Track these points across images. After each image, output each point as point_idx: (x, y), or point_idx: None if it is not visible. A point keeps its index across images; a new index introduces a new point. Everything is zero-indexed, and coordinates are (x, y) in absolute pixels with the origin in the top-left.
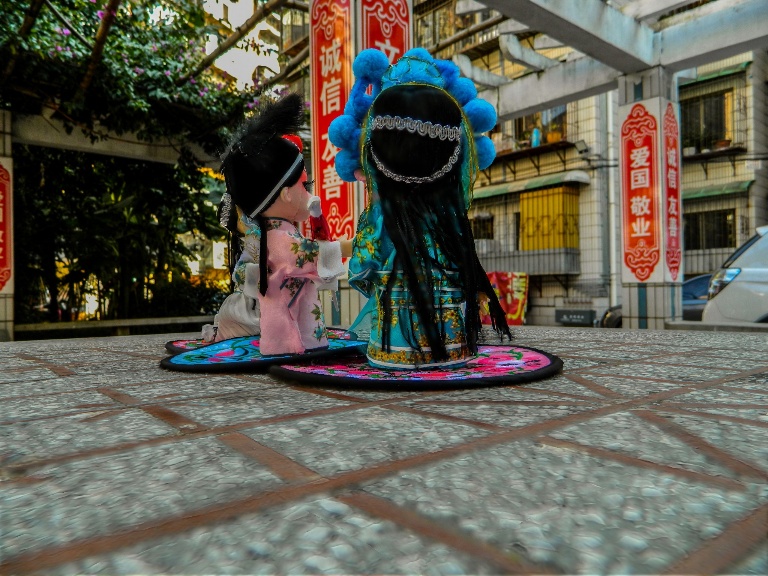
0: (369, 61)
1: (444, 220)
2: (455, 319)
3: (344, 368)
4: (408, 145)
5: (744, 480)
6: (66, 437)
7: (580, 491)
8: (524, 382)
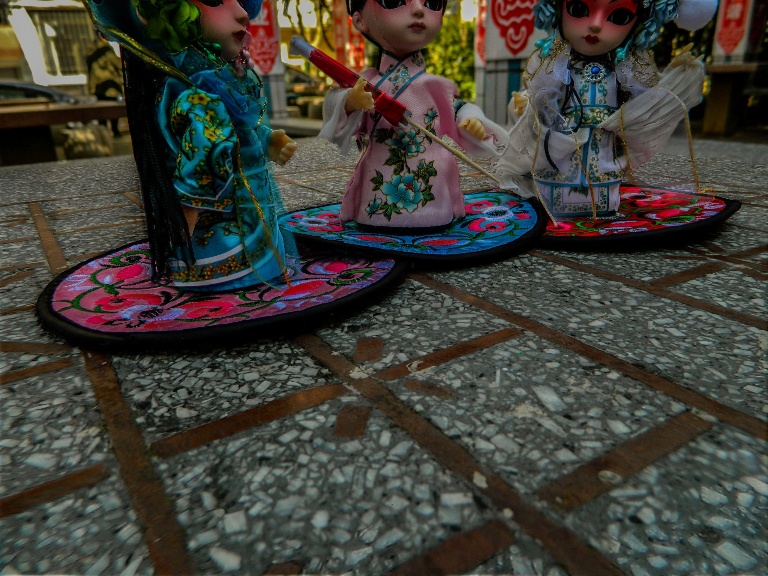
0: None
1: None
2: None
3: None
4: None
5: None
6: None
7: None
8: None
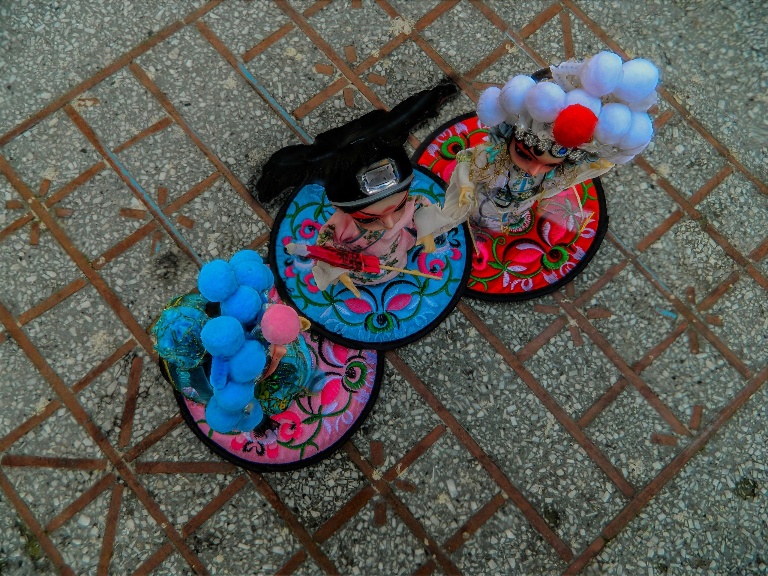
0: None
1: None
2: None
3: None
4: None
5: (6, 455)
6: (95, 218)
7: (3, 400)
8: None
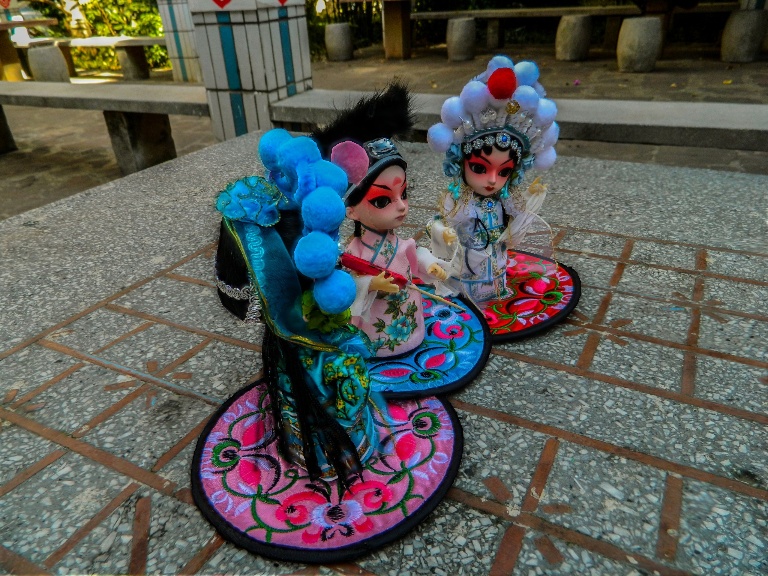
0: None
1: None
2: None
3: None
4: None
5: None
6: None
7: None
8: None
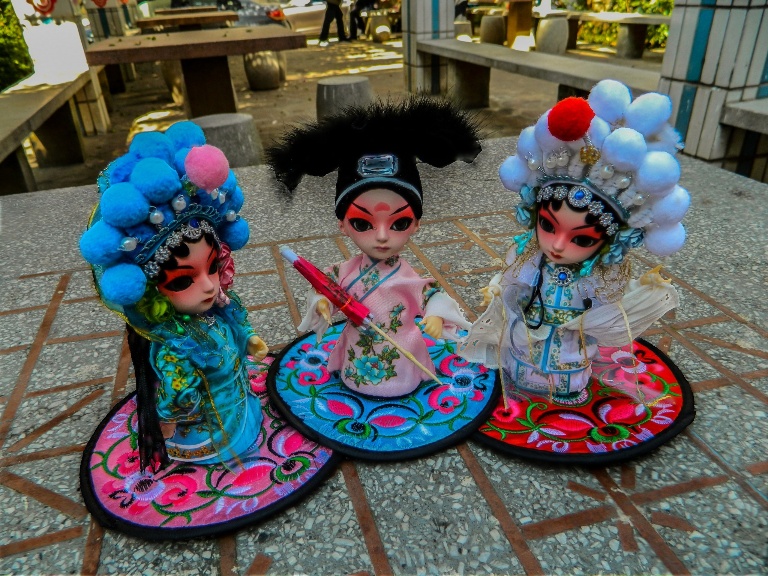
0: None
1: None
2: None
3: None
4: None
5: None
6: None
7: None
8: None
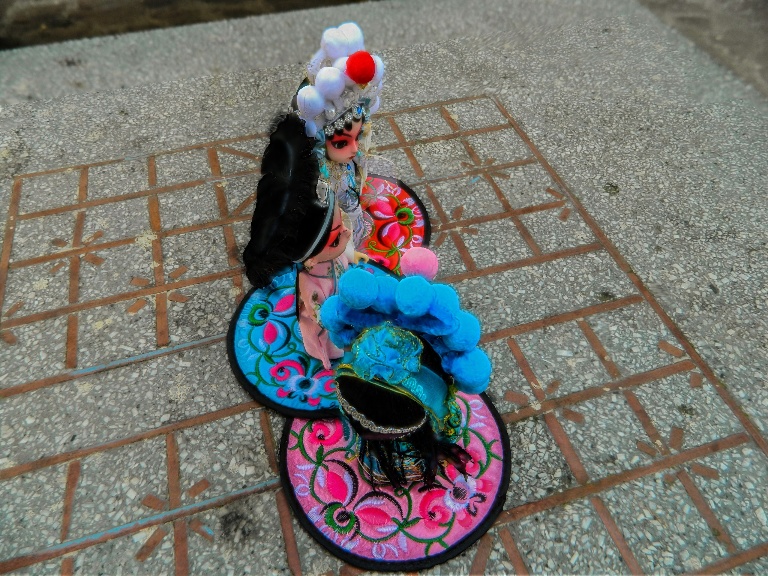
0: (349, 302)
1: (411, 433)
2: (416, 469)
3: (338, 439)
4: (361, 431)
5: None
6: None
7: None
8: (427, 568)
